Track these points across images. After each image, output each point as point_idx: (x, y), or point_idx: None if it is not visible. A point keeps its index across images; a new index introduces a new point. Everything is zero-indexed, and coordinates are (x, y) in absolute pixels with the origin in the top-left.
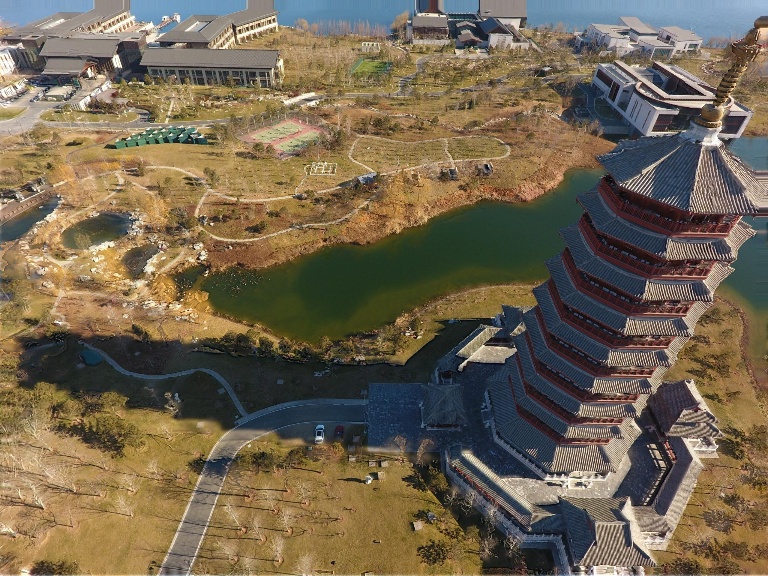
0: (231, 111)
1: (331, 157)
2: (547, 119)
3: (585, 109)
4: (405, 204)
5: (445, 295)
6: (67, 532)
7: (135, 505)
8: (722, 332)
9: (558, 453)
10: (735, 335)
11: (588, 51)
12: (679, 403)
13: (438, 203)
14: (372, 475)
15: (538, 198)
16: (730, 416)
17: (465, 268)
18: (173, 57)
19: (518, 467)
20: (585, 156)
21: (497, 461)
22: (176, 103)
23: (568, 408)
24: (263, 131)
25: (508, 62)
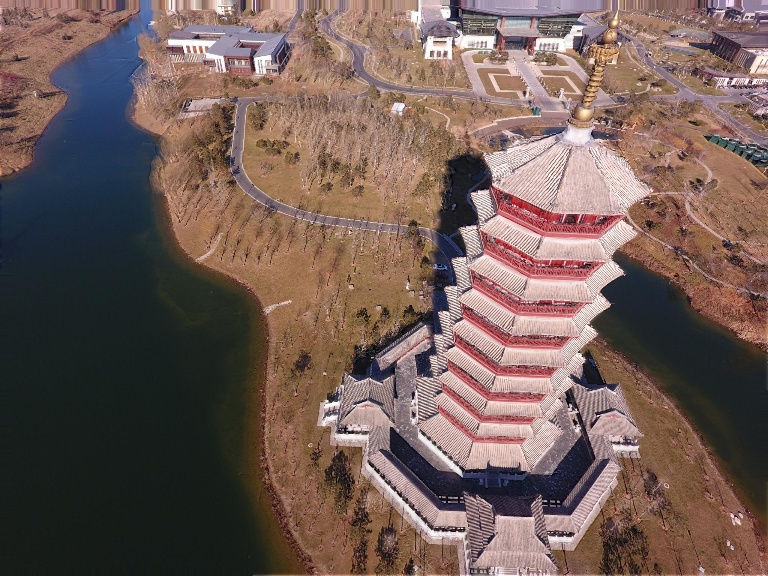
0: None
1: None
2: None
3: None
4: None
5: (644, 372)
6: (376, 190)
7: (389, 206)
8: None
9: (431, 381)
10: None
11: None
12: (502, 507)
13: None
14: (413, 290)
15: None
16: None
17: (716, 404)
18: None
19: None
20: None
21: None
22: None
23: None
24: None
25: None
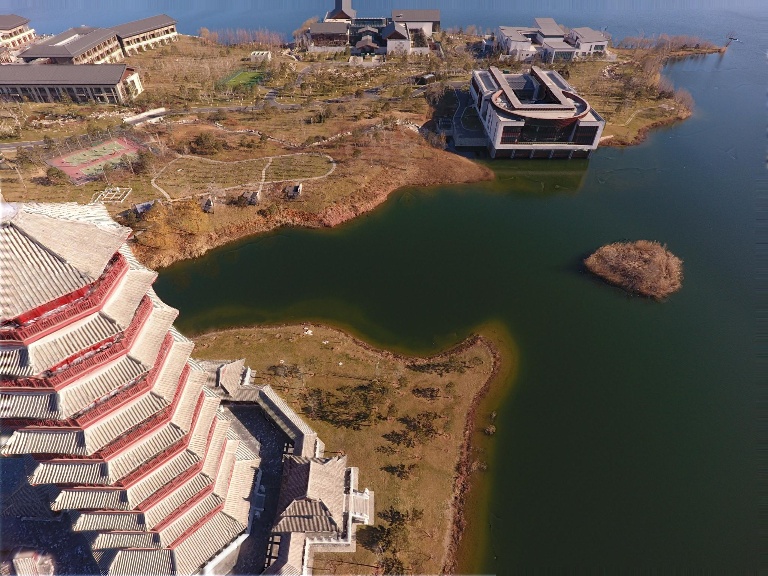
0: (60, 131)
1: (131, 181)
2: (397, 132)
3: (447, 120)
4: (186, 233)
5: None
6: None
7: None
8: (446, 386)
9: (120, 559)
10: (474, 386)
11: (489, 55)
12: (296, 490)
13: (227, 231)
14: None
15: (346, 222)
16: (402, 494)
17: (219, 307)
18: (14, 74)
19: (97, 570)
20: (420, 173)
21: (77, 562)
22: (6, 123)
23: (72, 518)
24: (78, 153)
25: (400, 69)
